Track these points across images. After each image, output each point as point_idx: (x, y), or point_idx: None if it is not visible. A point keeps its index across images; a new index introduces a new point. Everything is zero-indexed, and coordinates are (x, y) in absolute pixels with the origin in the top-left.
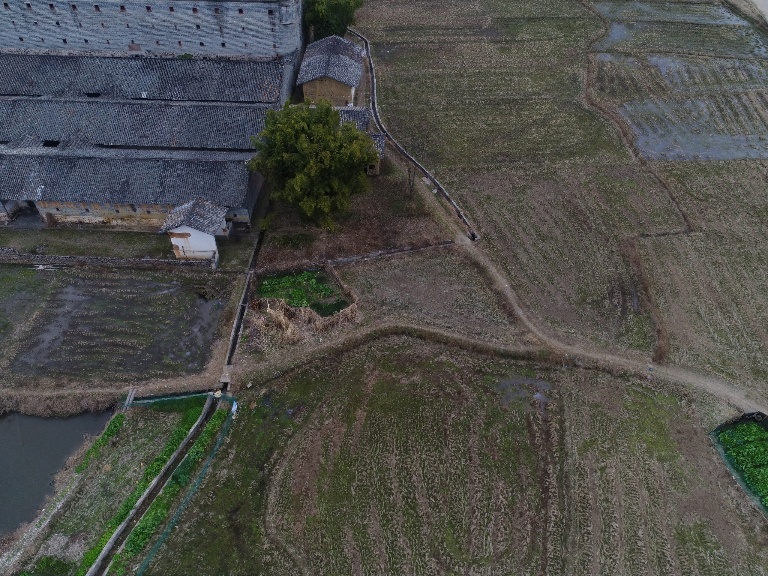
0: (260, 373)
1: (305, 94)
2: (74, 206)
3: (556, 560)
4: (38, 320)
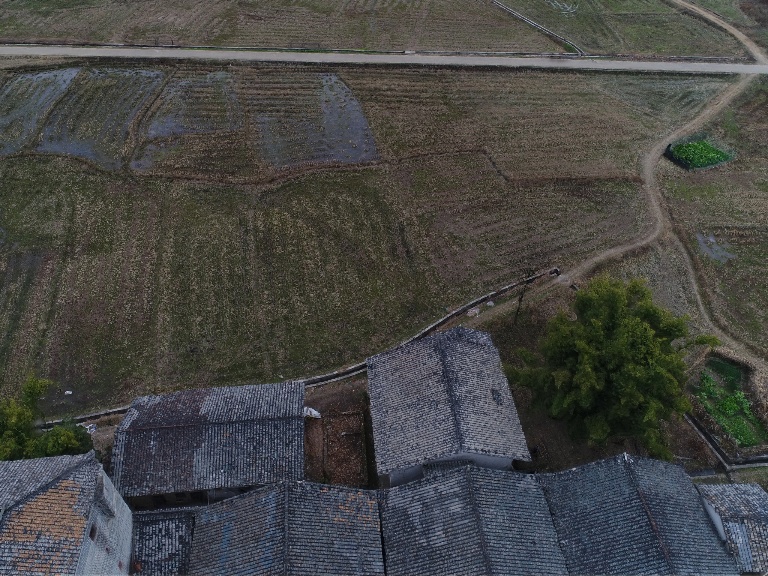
0: None
1: None
2: None
3: None
4: None
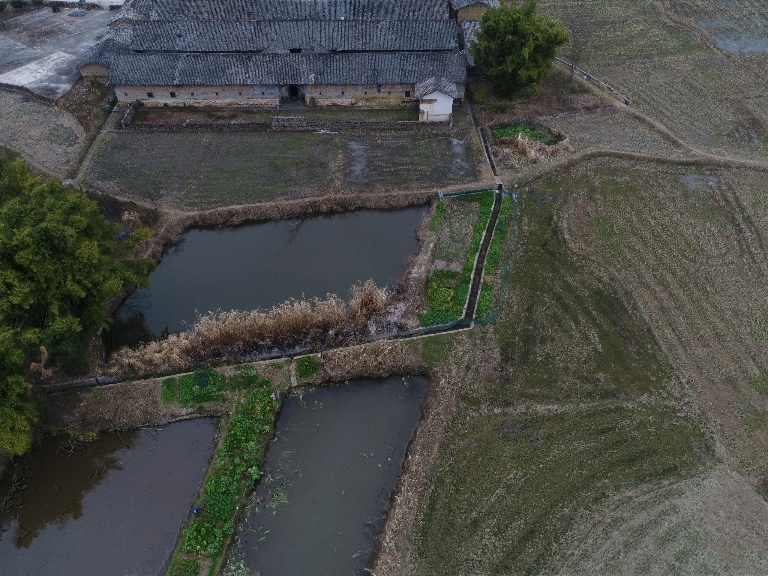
0: (520, 179)
1: (459, 19)
2: (334, 90)
3: (760, 254)
4: (344, 159)
